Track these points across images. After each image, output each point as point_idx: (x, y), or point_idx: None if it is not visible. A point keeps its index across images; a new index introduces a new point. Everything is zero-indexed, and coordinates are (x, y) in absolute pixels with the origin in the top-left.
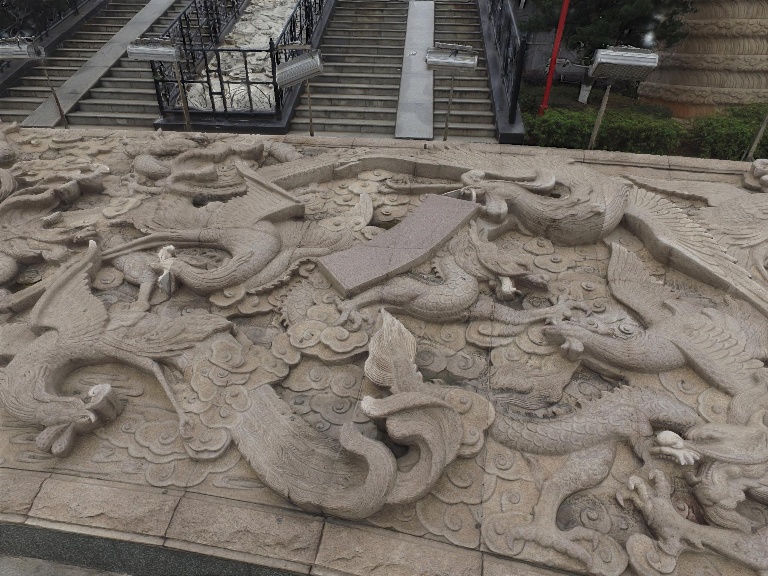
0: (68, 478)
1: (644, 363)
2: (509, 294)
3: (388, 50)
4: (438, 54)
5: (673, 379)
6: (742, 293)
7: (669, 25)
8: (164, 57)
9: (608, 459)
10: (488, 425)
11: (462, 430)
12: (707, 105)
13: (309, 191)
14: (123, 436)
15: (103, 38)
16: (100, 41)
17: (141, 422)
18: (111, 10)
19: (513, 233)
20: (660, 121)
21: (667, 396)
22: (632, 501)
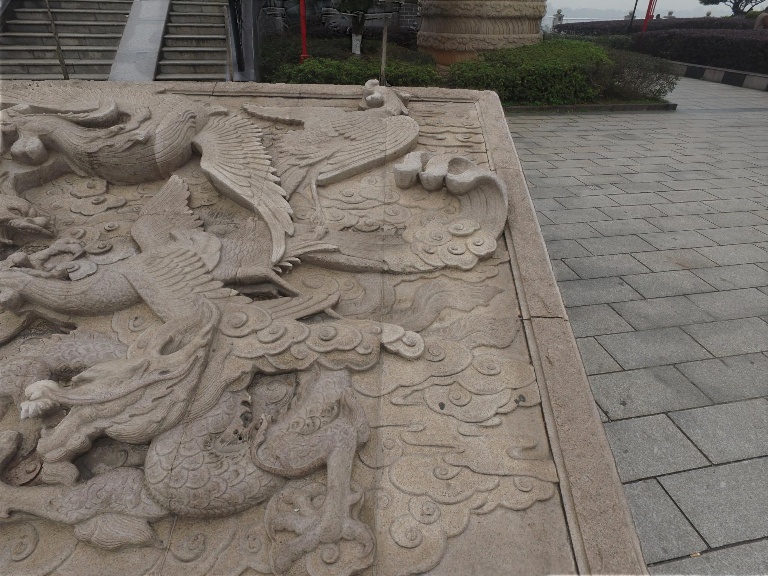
0: None
1: (83, 304)
2: None
3: None
4: None
5: (127, 317)
6: (259, 213)
7: None
8: None
9: None
10: None
11: None
12: (469, 52)
13: None
14: None
15: None
16: None
17: None
18: None
19: (70, 176)
20: (416, 67)
21: (106, 338)
22: None
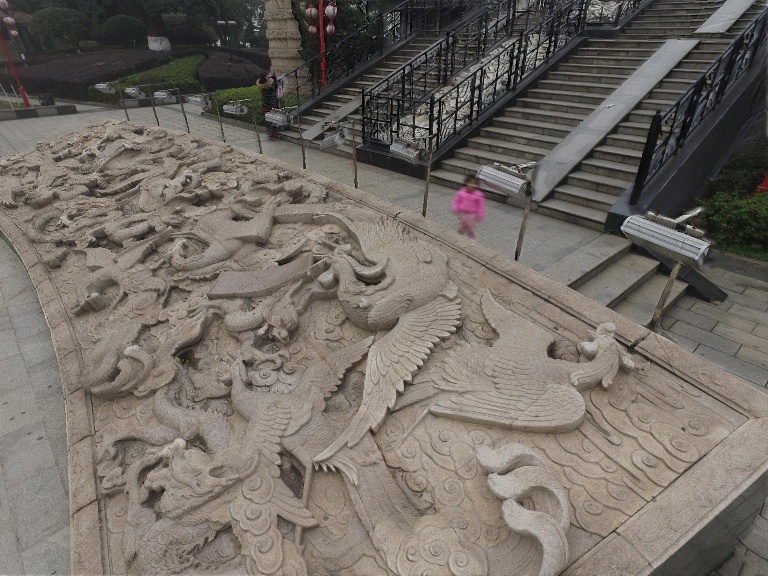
0: (70, 324)
1: (235, 407)
2: None
3: (591, 99)
4: (399, 145)
5: (245, 428)
6: None
7: None
8: (278, 122)
9: (168, 438)
10: (154, 388)
11: (136, 380)
12: None
13: (292, 228)
14: (94, 318)
15: (387, 74)
16: (381, 77)
17: (102, 316)
18: (407, 50)
19: None
20: None
21: (229, 433)
22: None
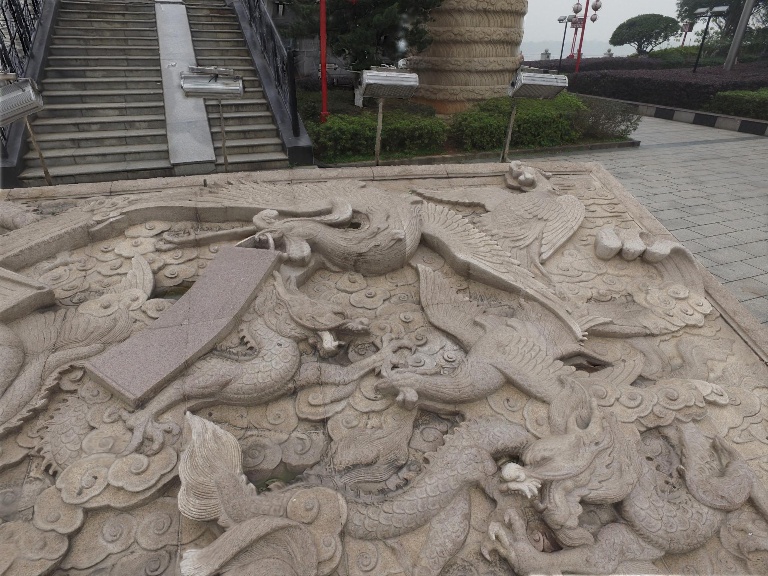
0: None
1: (473, 394)
2: (332, 350)
3: (140, 61)
4: (195, 79)
5: (500, 400)
6: (531, 295)
7: (416, 33)
8: None
9: (466, 512)
10: (342, 525)
11: (315, 549)
12: (459, 101)
13: (58, 264)
14: None
15: None
16: None
17: None
18: None
19: (322, 272)
20: (427, 120)
21: (499, 420)
22: (496, 550)
